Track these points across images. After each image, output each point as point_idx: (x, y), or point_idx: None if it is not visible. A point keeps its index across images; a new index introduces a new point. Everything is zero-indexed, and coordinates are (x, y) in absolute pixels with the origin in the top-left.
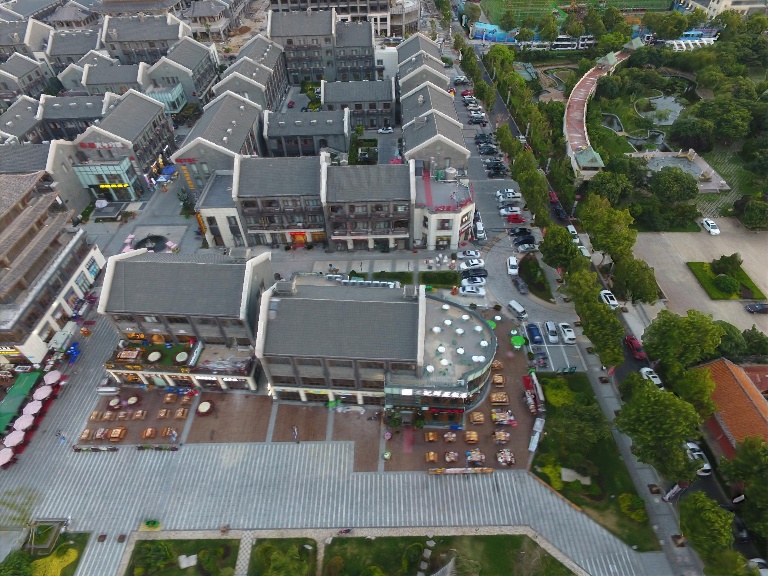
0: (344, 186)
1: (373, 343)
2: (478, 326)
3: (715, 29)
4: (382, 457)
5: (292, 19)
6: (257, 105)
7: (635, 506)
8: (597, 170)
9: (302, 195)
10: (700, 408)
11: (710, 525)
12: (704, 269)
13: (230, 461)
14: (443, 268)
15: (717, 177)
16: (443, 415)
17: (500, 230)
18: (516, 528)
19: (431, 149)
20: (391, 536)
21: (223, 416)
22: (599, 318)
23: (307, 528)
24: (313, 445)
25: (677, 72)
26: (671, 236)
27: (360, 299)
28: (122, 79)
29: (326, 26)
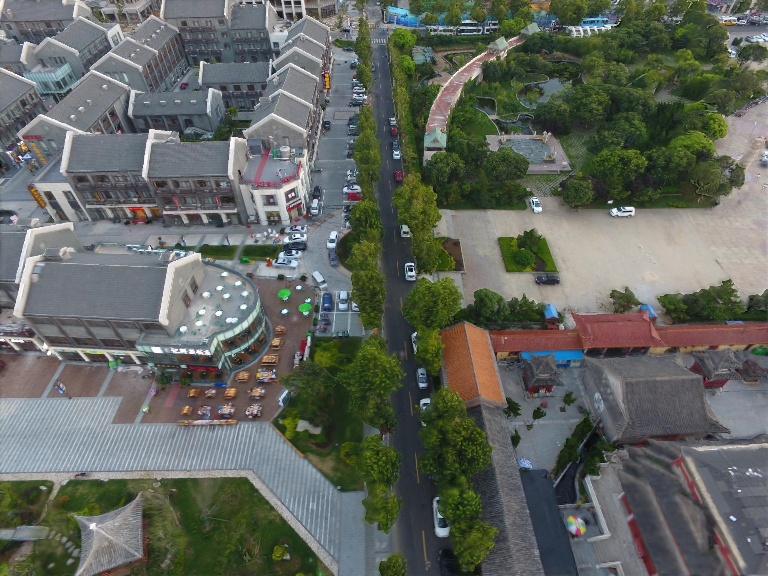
0: (167, 162)
1: (124, 304)
2: (245, 291)
3: (621, 16)
4: (142, 411)
5: (186, 1)
6: (123, 85)
7: (349, 452)
8: (441, 150)
9: (129, 171)
10: (428, 365)
11: (366, 462)
12: (511, 244)
13: (1, 414)
14: (268, 242)
15: (563, 159)
16: (210, 374)
17: (337, 207)
18: (239, 472)
19: (267, 128)
20: (124, 479)
21: (10, 375)
22: (361, 285)
23: (50, 472)
24: (83, 400)
25: (571, 58)
26: (496, 213)
27: (120, 264)
28: (6, 58)
29: (219, 8)
